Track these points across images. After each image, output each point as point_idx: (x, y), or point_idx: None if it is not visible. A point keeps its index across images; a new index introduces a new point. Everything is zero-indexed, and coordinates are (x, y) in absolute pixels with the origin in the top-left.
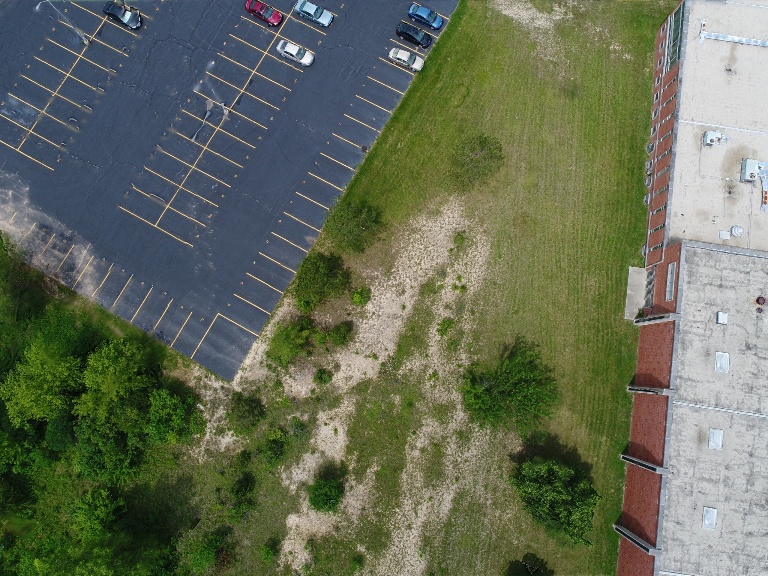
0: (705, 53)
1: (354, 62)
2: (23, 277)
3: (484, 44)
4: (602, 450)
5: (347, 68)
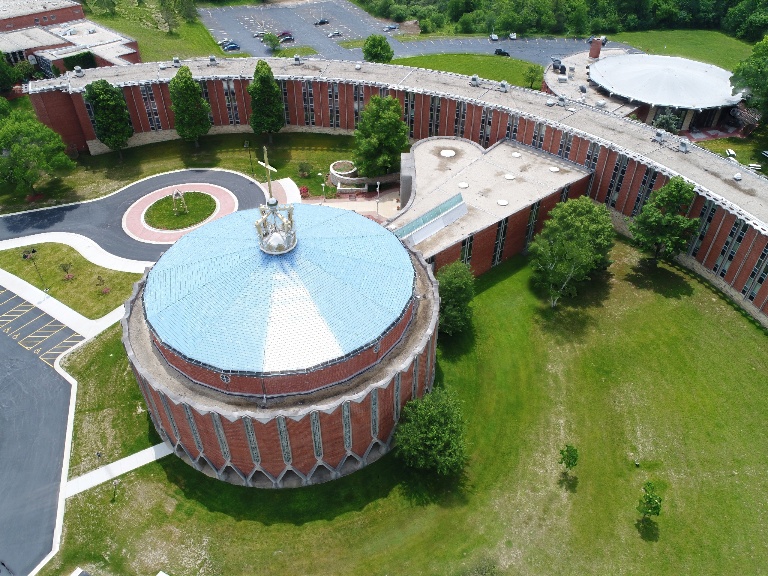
0: None
1: None
2: (267, 2)
3: None
4: None
5: None
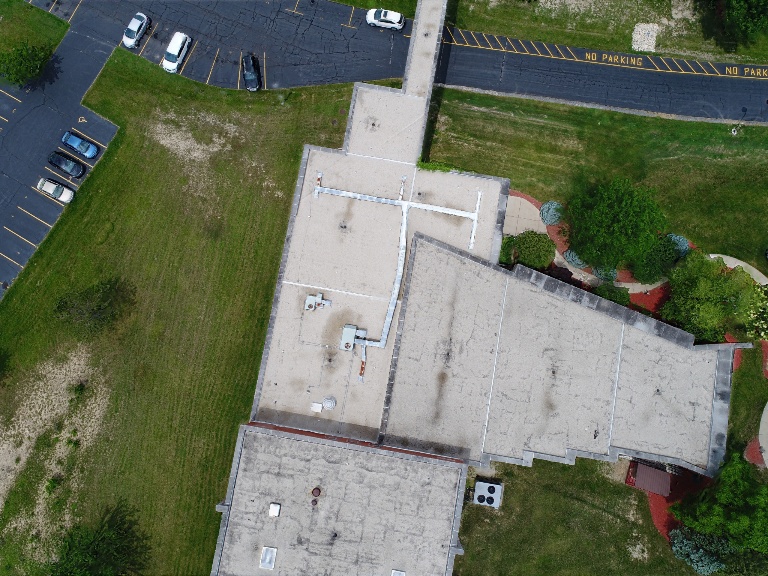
0: (320, 208)
1: (6, 190)
2: None
3: (136, 176)
4: None
5: None
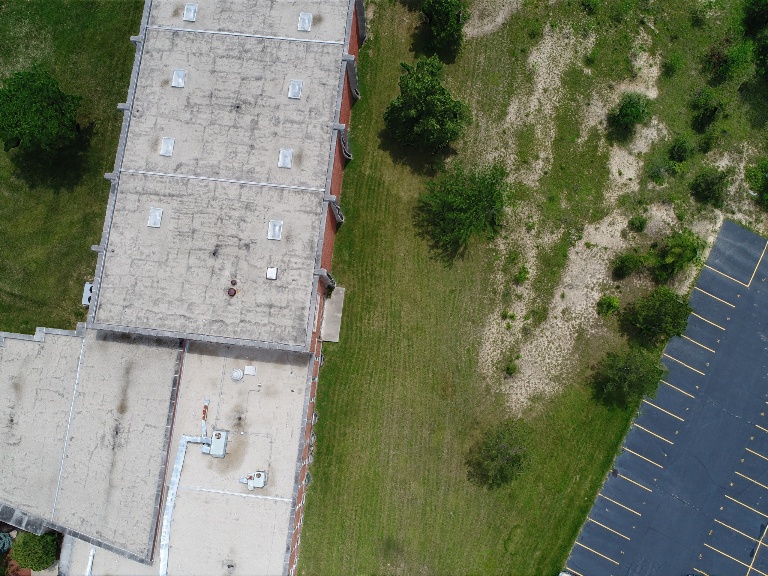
0: None
1: None
2: None
3: None
4: (369, 162)
5: (643, 575)
